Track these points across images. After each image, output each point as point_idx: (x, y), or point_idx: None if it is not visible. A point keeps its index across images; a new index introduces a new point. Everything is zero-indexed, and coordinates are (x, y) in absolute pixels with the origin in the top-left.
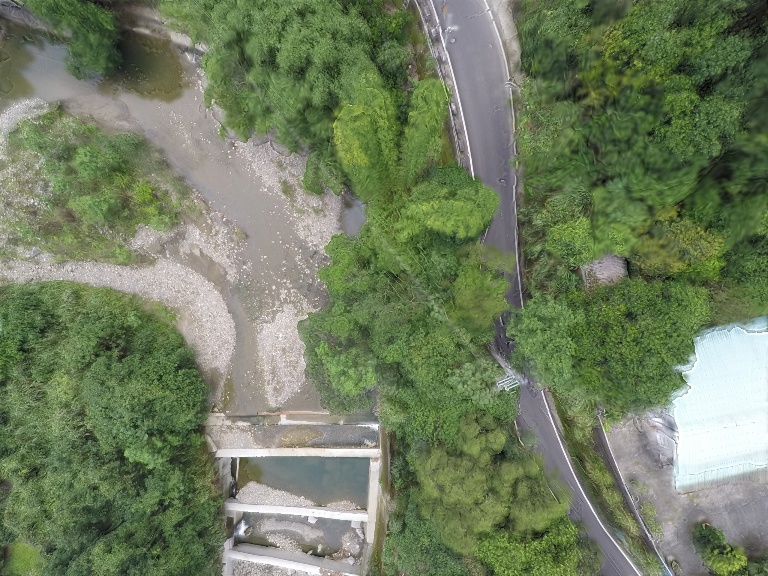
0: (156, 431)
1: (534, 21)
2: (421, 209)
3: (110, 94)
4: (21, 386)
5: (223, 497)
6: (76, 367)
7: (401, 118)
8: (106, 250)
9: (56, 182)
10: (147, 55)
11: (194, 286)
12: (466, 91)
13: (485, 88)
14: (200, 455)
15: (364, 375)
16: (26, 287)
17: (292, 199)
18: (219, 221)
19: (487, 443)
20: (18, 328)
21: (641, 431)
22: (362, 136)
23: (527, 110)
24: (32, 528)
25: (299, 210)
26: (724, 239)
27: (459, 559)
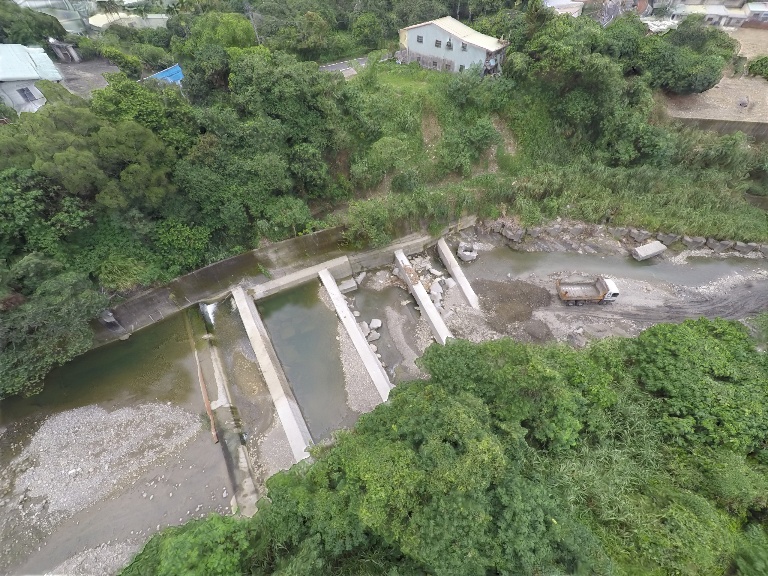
0: None
1: None
2: None
3: None
4: None
5: None
6: None
7: None
8: None
9: None
10: None
11: None
12: None
13: None
14: None
15: None
16: None
17: None
18: None
19: None
20: None
21: None
22: None
23: None
24: None
25: None
26: None
27: (213, 156)
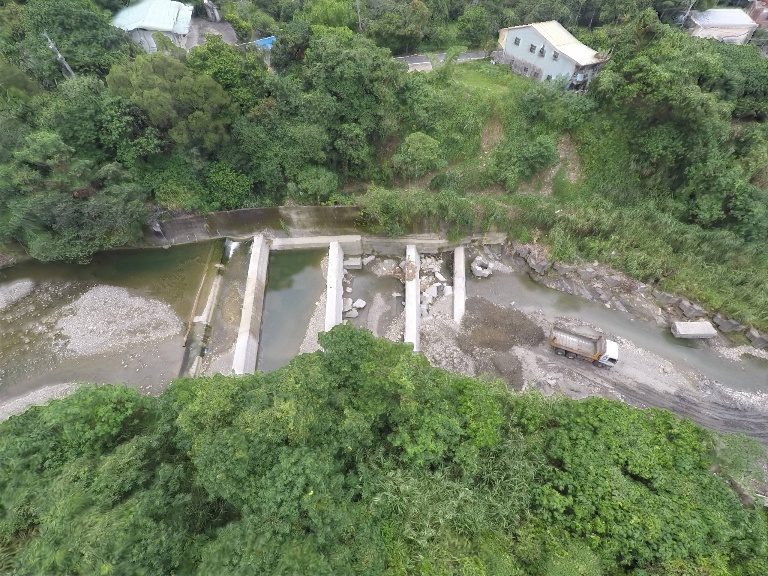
0: None
1: None
2: None
3: None
4: None
5: None
6: None
7: None
8: None
9: None
10: None
11: None
12: None
13: None
14: None
15: None
16: None
17: None
18: None
19: None
20: None
21: (128, 32)
22: None
23: None
24: None
25: None
26: (4, 3)
27: None
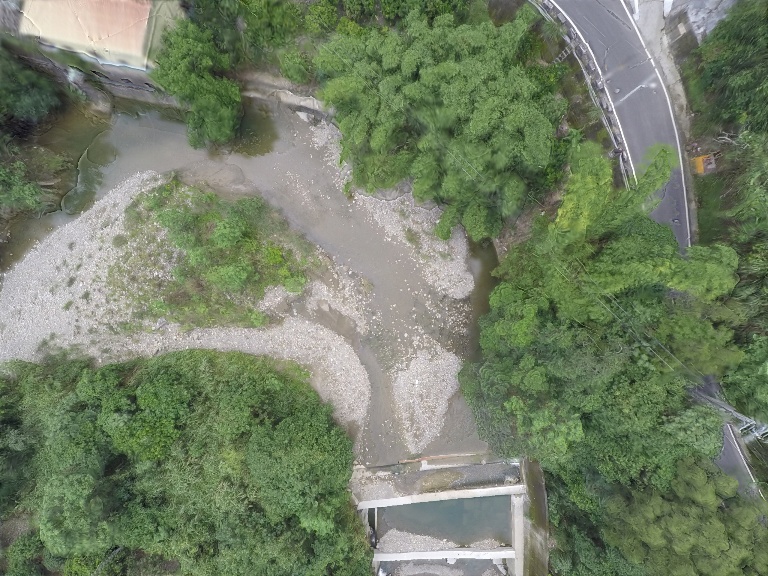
0: (319, 495)
1: (747, 78)
2: (658, 270)
3: (223, 159)
4: (178, 465)
5: None
6: (231, 439)
7: (555, 166)
8: (235, 315)
9: (194, 256)
10: (263, 119)
11: (325, 342)
12: (633, 138)
13: (652, 133)
14: (349, 511)
15: (573, 429)
16: (160, 361)
17: (417, 246)
18: (345, 275)
19: (717, 487)
20: (169, 406)
21: None
22: (595, 205)
23: (697, 151)
24: None
25: (426, 256)
26: None
27: None
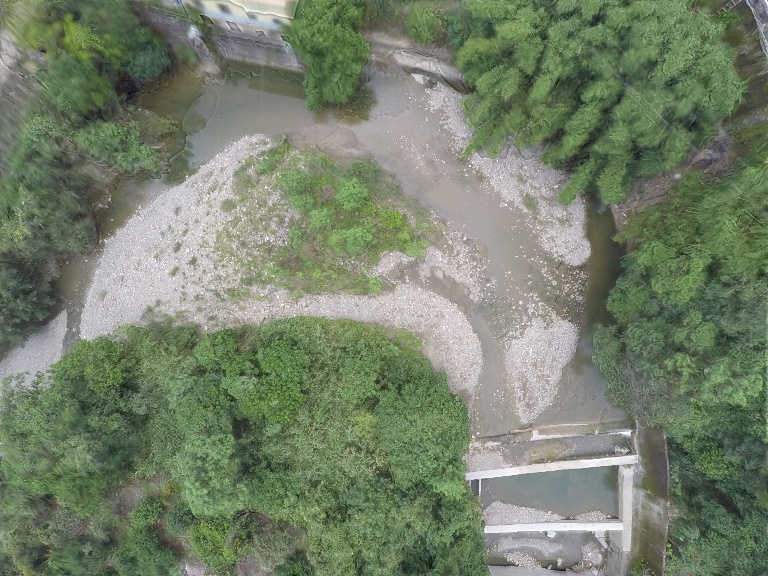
0: None
1: None
2: None
3: (334, 123)
4: (304, 429)
5: (483, 521)
6: (357, 404)
7: None
8: (348, 281)
9: (319, 217)
10: (382, 80)
11: (438, 309)
12: None
13: None
14: None
15: None
16: (274, 327)
17: (535, 212)
18: (459, 241)
19: None
20: (294, 370)
21: None
22: None
23: None
24: (341, 575)
25: (543, 222)
26: None
27: None
